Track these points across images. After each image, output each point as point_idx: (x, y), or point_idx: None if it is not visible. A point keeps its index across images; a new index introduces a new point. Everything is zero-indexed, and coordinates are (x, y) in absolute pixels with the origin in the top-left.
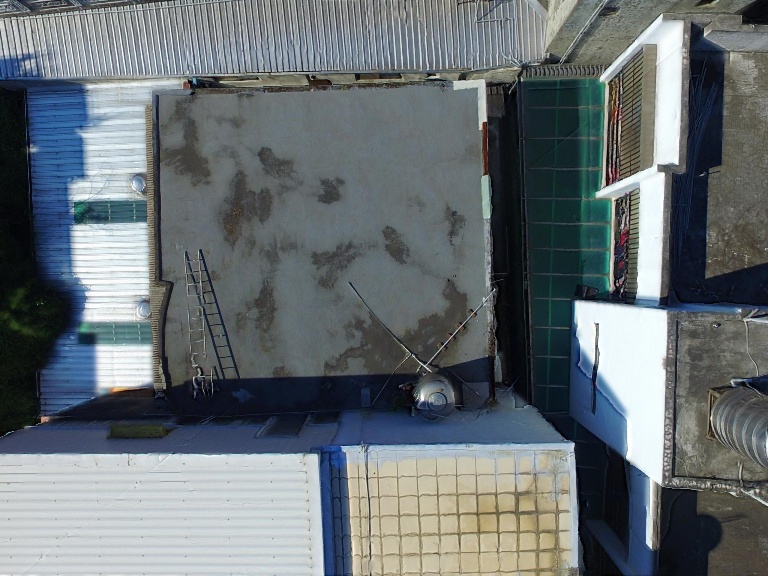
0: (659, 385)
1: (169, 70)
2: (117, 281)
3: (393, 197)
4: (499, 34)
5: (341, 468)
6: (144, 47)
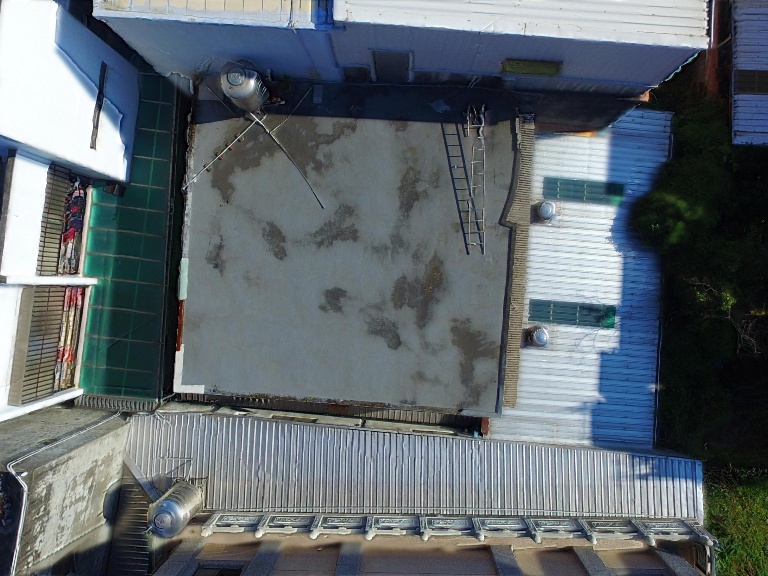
0: (4, 61)
1: (499, 447)
2: (577, 244)
3: (274, 288)
4: (173, 445)
5: (318, 7)
6: (522, 473)
